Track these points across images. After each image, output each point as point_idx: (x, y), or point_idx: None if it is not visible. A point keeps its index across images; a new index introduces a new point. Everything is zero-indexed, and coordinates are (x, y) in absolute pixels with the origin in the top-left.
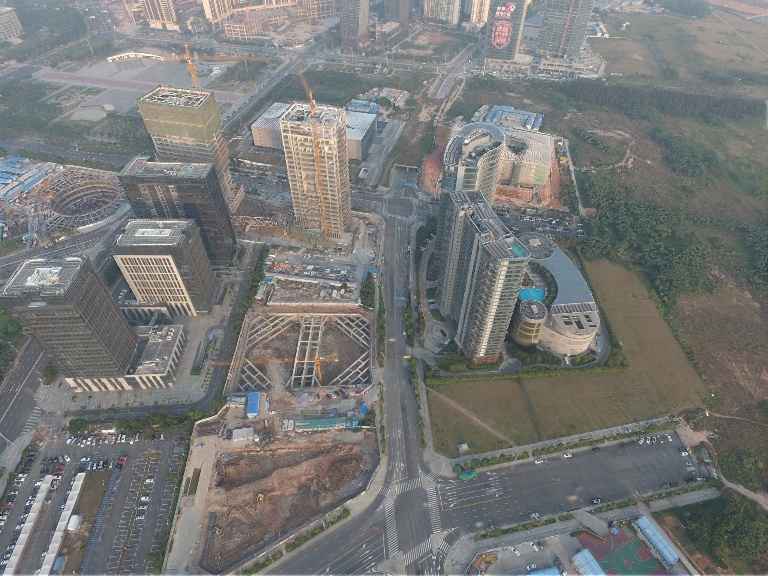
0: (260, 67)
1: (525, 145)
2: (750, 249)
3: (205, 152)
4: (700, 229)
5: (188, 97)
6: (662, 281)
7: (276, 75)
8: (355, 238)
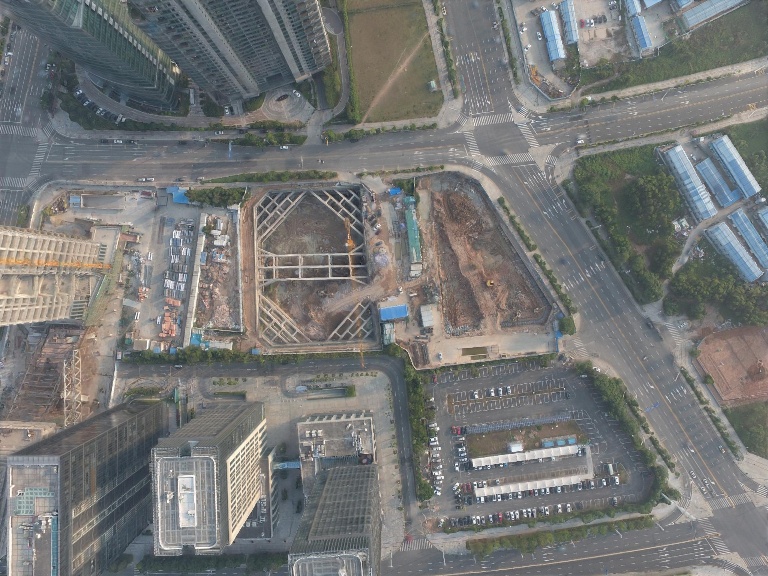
0: None
1: None
2: None
3: None
4: None
5: None
6: None
7: None
8: None
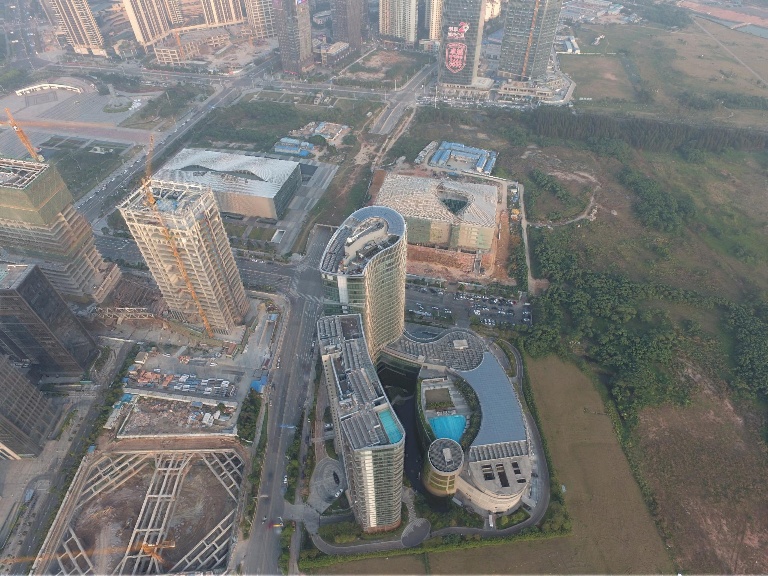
0: (187, 99)
1: (467, 199)
2: (731, 335)
3: (48, 237)
4: (672, 306)
5: (22, 170)
6: (621, 389)
7: (203, 108)
8: (249, 331)
